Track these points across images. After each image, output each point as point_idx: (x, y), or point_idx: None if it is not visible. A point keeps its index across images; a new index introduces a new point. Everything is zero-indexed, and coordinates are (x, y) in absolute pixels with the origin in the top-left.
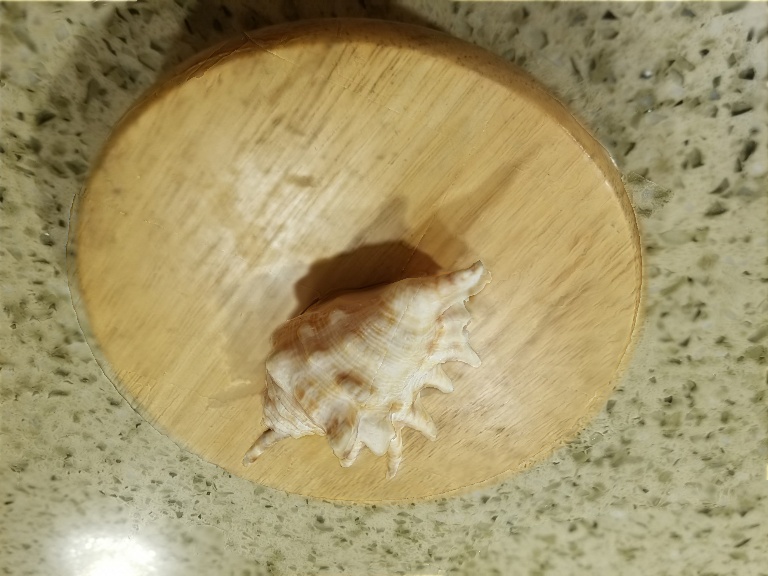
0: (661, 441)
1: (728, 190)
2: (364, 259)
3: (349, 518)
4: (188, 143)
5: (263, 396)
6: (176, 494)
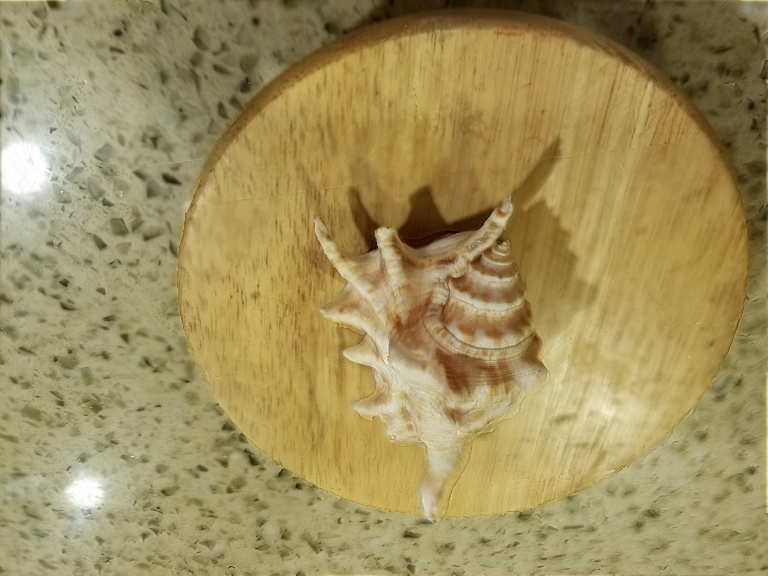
0: (8, 239)
1: (238, 439)
2: None
3: None
4: (655, 398)
5: None
6: None
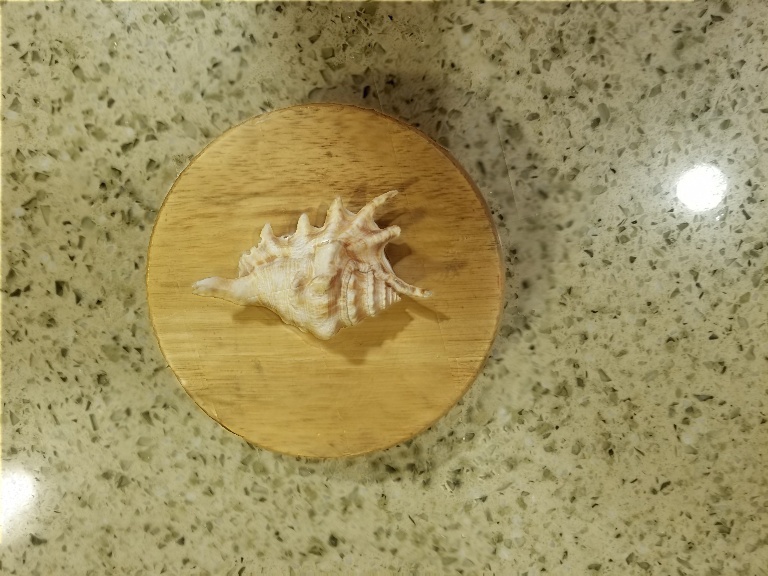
0: None
1: (149, 134)
2: None
3: (576, 104)
4: (284, 424)
5: None
6: (656, 244)
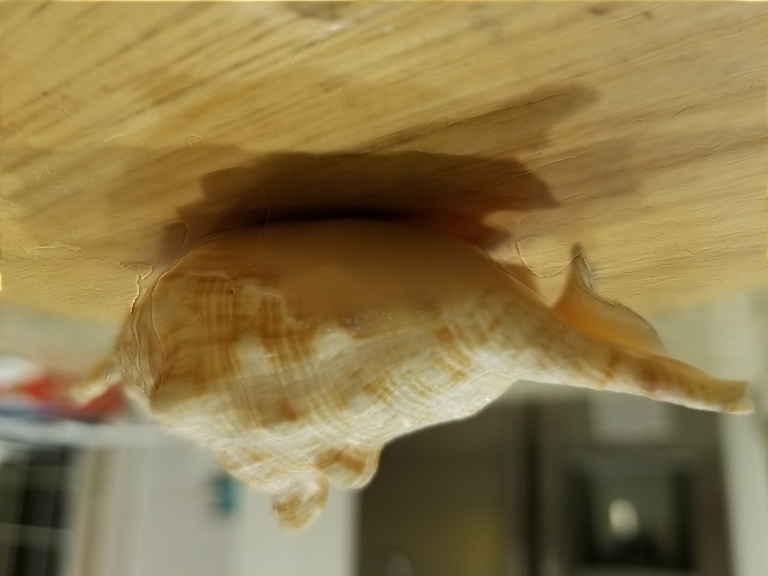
0: None
1: None
2: (398, 164)
3: None
4: None
5: (126, 355)
6: None
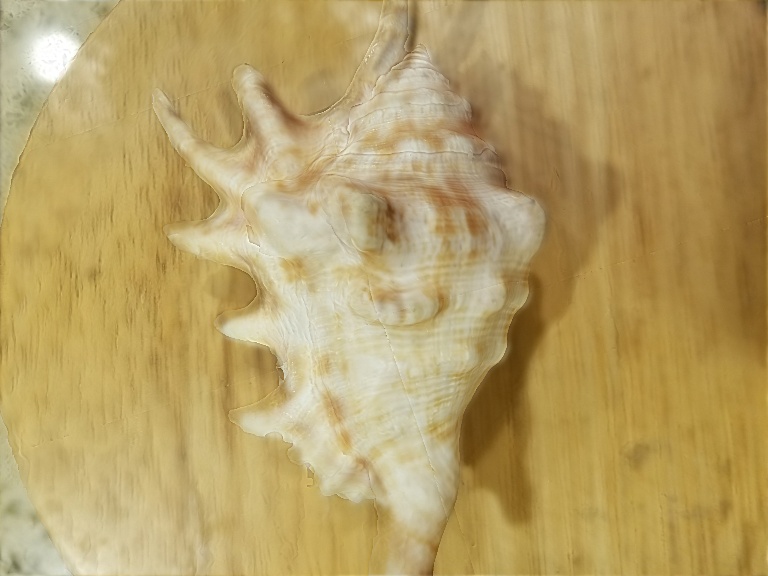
0: None
1: None
2: (487, 398)
3: None
4: None
5: (470, 111)
6: None
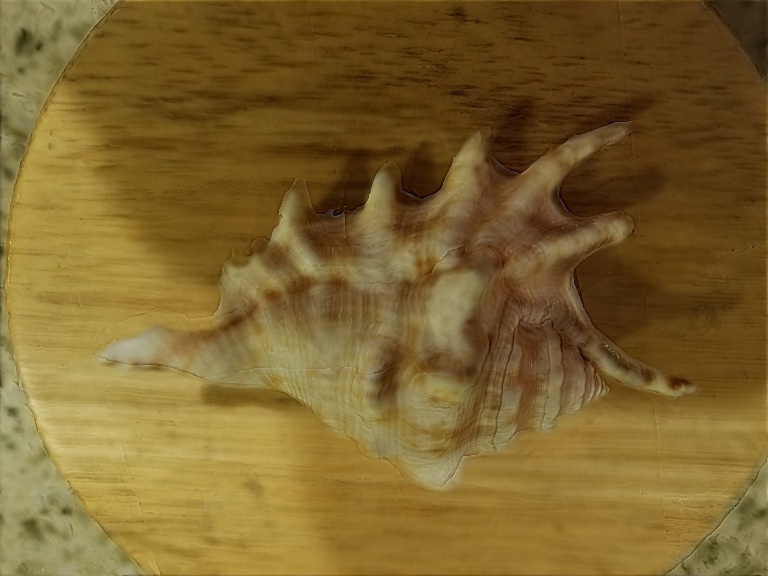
0: None
1: None
2: None
3: None
4: None
5: None
6: None
